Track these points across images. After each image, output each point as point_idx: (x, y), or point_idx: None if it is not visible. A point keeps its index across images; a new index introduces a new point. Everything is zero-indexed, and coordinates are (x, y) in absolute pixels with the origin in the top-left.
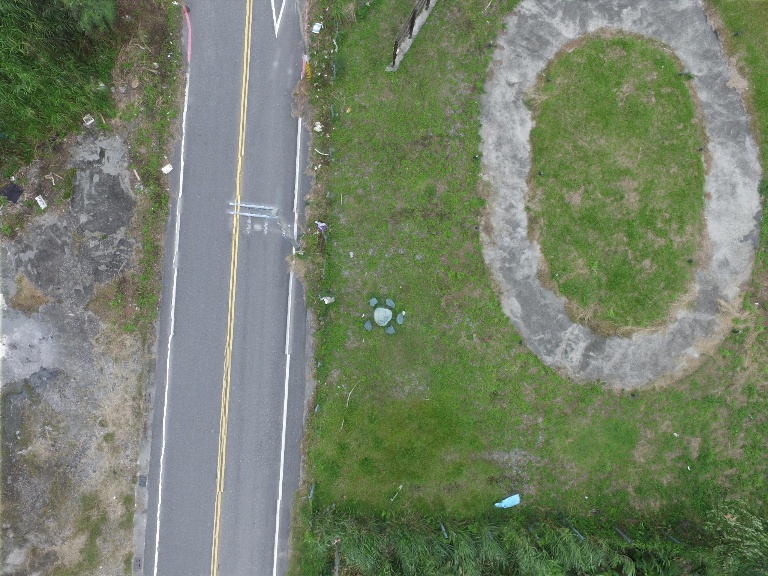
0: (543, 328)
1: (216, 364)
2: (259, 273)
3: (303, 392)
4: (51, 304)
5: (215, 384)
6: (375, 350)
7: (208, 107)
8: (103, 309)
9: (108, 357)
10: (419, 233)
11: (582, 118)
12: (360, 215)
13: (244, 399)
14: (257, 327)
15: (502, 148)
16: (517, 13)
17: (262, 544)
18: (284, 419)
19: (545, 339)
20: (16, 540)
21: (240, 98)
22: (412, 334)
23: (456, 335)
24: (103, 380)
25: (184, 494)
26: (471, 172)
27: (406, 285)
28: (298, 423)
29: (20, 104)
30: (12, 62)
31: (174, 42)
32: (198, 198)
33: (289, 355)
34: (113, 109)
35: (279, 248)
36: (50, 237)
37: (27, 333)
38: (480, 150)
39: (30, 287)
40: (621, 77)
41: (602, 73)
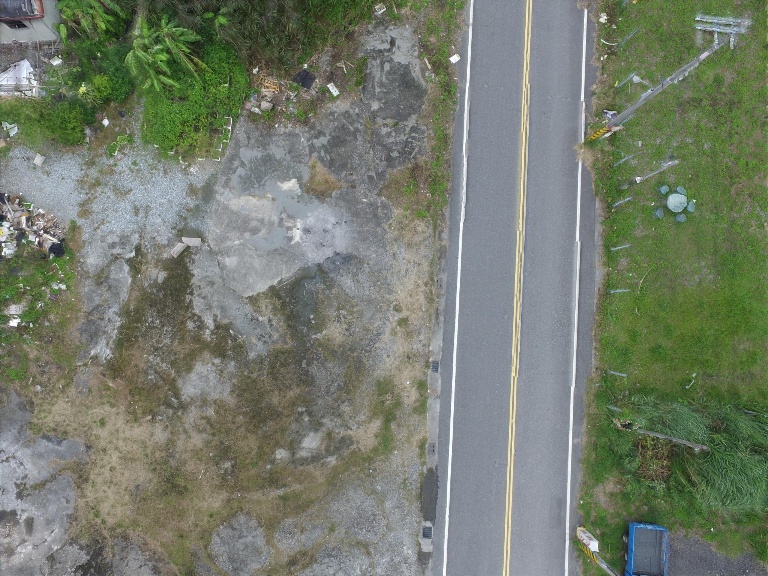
0: None
1: (508, 250)
2: (549, 161)
3: (593, 280)
4: (344, 189)
5: (507, 270)
6: (665, 238)
7: None
8: (395, 195)
9: (400, 243)
10: (707, 122)
11: None
12: (648, 104)
13: (536, 286)
14: (547, 214)
15: None
16: None
17: (557, 431)
18: (576, 306)
19: None
20: (311, 423)
21: None
22: (703, 222)
23: (747, 224)
24: (396, 265)
25: (478, 379)
26: (760, 62)
27: (695, 174)
28: (589, 310)
29: None
30: None
31: None
32: (486, 87)
33: (580, 242)
34: None
35: (567, 137)
36: (342, 124)
37: (321, 218)
38: None
39: (324, 172)
40: None
41: None
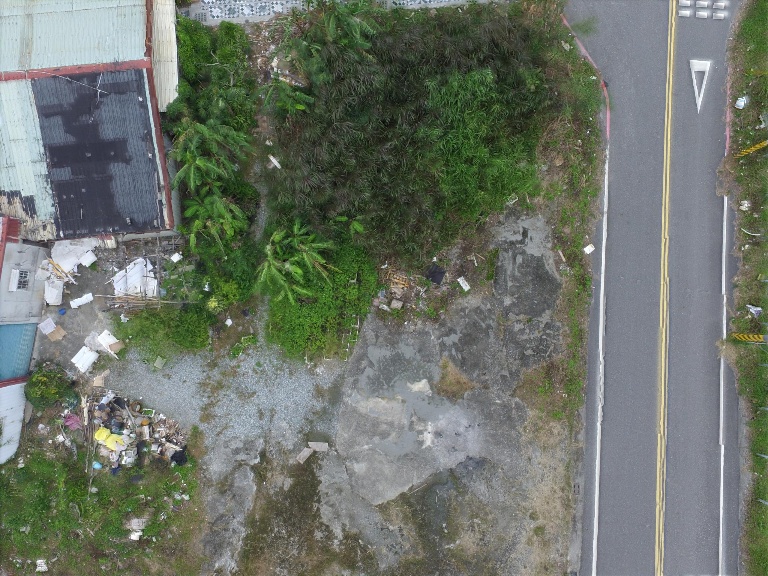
0: None
1: (648, 454)
2: (689, 359)
3: (738, 484)
4: (477, 390)
5: (648, 476)
6: None
7: (630, 185)
8: (529, 396)
9: (536, 446)
10: None
11: None
12: None
13: (678, 492)
14: (689, 415)
15: None
16: None
17: None
18: (721, 513)
19: None
20: None
21: (662, 175)
22: None
23: None
24: (531, 470)
25: None
26: None
27: None
28: (734, 517)
29: (474, 188)
30: (478, 147)
31: (594, 118)
32: (622, 279)
33: (723, 445)
34: (538, 188)
35: (708, 332)
36: (474, 320)
37: (453, 421)
38: None
39: (455, 372)
40: None
41: None
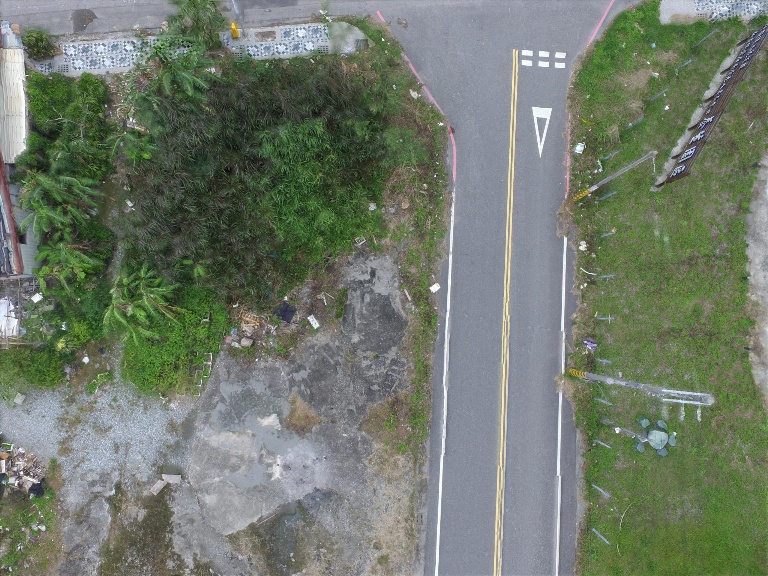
0: None
1: (488, 485)
2: (529, 393)
3: (575, 514)
4: (324, 424)
5: (488, 506)
6: (647, 472)
7: (474, 226)
8: (375, 429)
9: (380, 478)
10: (687, 353)
11: None
12: (628, 335)
13: (517, 521)
14: (528, 448)
15: None
16: None
17: None
18: (557, 542)
19: None
20: None
21: (505, 217)
22: (684, 456)
23: (728, 457)
24: (376, 501)
25: None
26: (739, 292)
27: (676, 405)
28: (571, 546)
29: (313, 233)
30: (313, 195)
31: (440, 163)
32: (466, 317)
33: (561, 476)
34: (384, 230)
35: (548, 367)
36: (322, 357)
37: (301, 453)
38: (747, 270)
39: (304, 407)
40: None
41: None
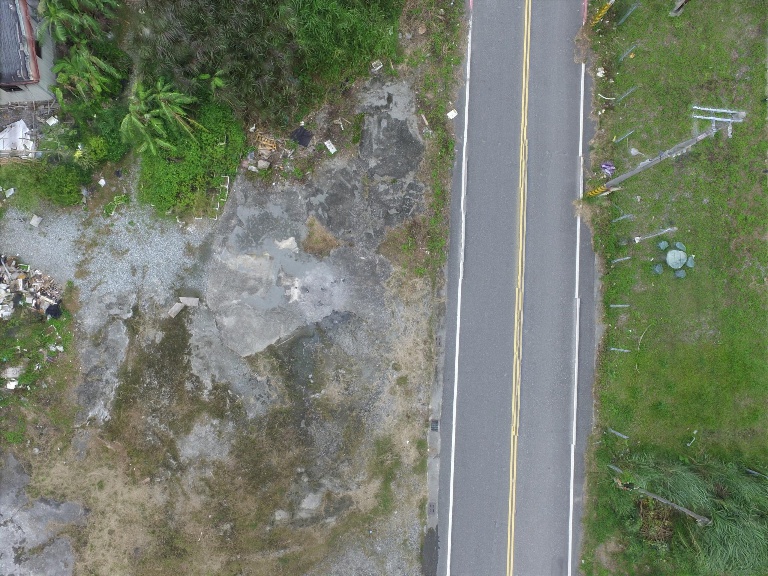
0: None
1: (507, 308)
2: (547, 217)
3: (593, 336)
4: (342, 247)
5: (506, 328)
6: (665, 294)
7: (491, 53)
8: (393, 253)
9: (399, 300)
10: (706, 177)
11: None
12: None
13: (535, 343)
14: (546, 271)
15: None
16: None
17: (558, 489)
18: (576, 363)
19: None
20: (311, 484)
21: (523, 44)
22: (702, 278)
23: (747, 279)
24: (394, 323)
25: (478, 438)
26: (758, 116)
27: (694, 229)
28: (589, 367)
29: (330, 45)
30: (331, 2)
31: None
32: (484, 143)
33: (579, 299)
34: (401, 55)
35: (566, 192)
36: (340, 181)
37: (319, 276)
38: (766, 94)
39: (321, 231)
40: None
41: None
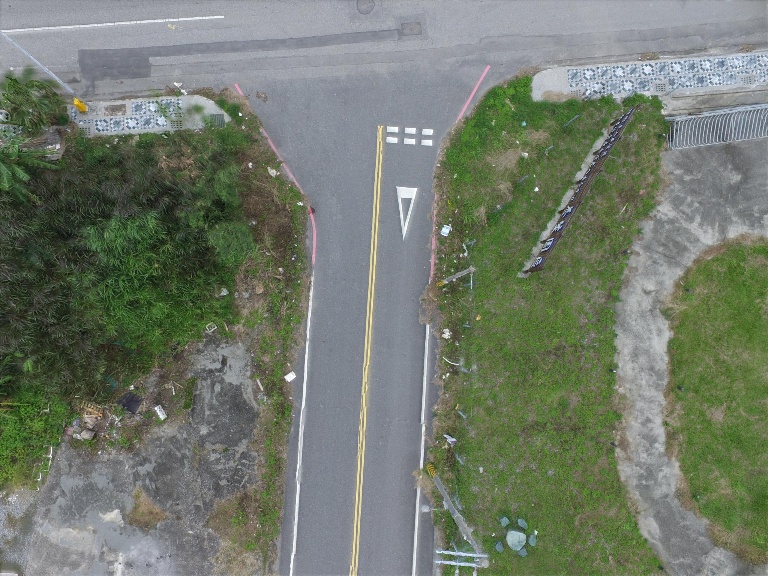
0: (683, 551)
1: None
2: (385, 489)
3: None
4: (169, 521)
5: None
6: (506, 572)
7: (333, 312)
8: (223, 526)
9: None
10: (552, 447)
11: (723, 331)
12: (490, 428)
13: None
14: (383, 546)
15: (638, 359)
16: (653, 218)
17: None
18: None
19: (685, 563)
20: None
21: (366, 303)
22: (545, 556)
23: (591, 557)
24: None
25: None
26: (606, 385)
27: (538, 503)
28: None
29: (150, 326)
30: (146, 288)
31: (299, 244)
32: (322, 408)
33: None
34: (237, 316)
35: (406, 462)
36: (169, 449)
37: (144, 551)
38: (616, 361)
39: (148, 503)
40: (763, 287)
41: (743, 283)
